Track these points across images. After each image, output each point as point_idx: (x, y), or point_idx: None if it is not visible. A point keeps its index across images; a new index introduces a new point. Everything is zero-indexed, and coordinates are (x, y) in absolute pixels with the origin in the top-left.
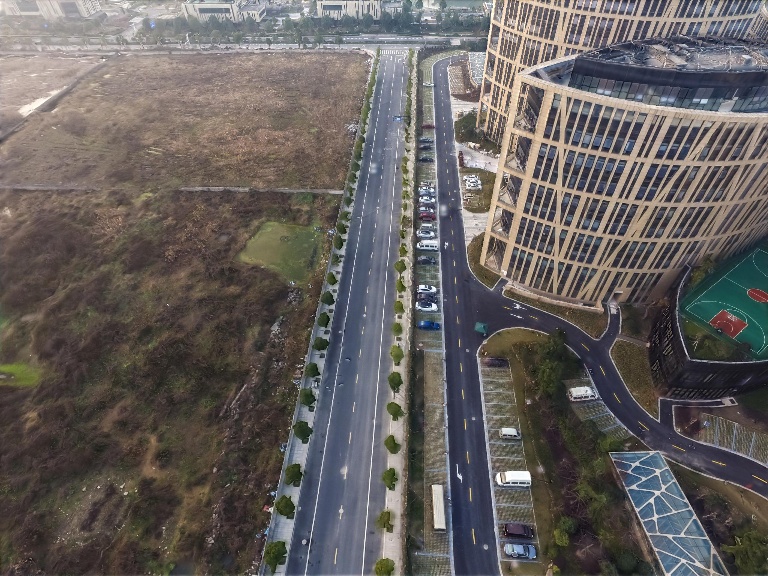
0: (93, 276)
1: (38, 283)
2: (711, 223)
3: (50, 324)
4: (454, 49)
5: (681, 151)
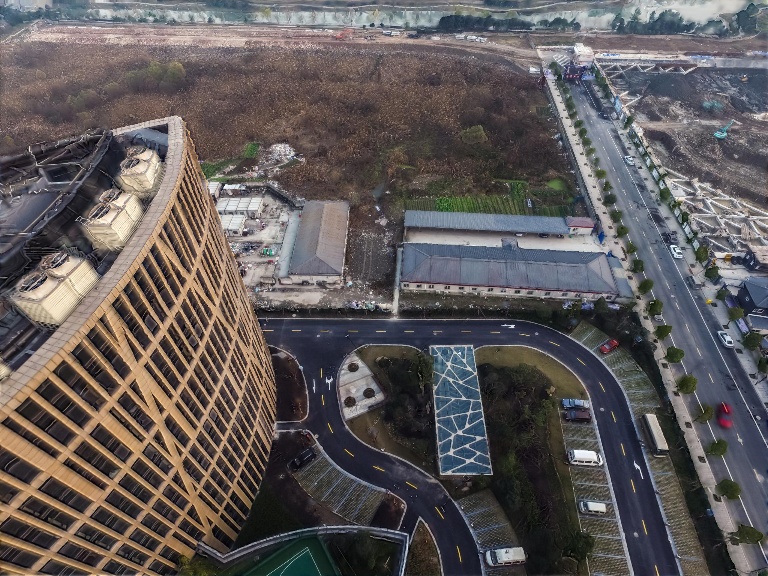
0: None
1: None
2: None
3: None
4: None
5: None
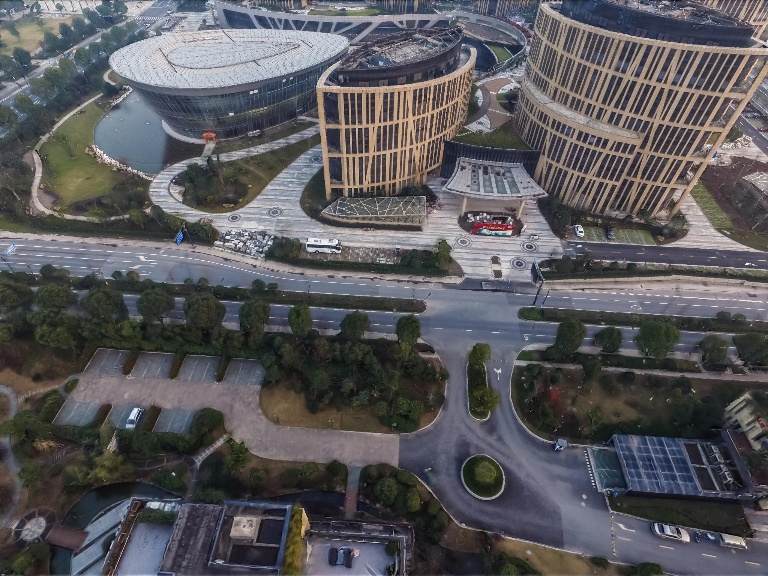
0: None
1: None
2: None
3: None
4: None
5: None
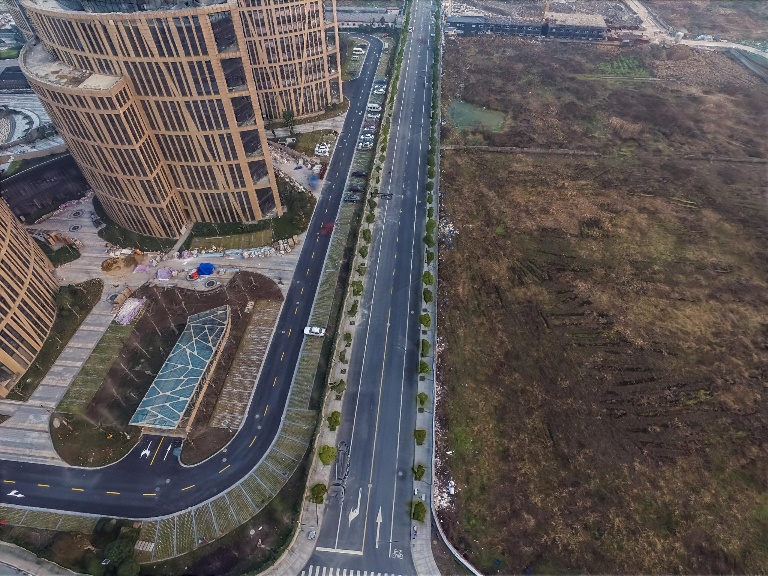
0: (593, 102)
1: (623, 97)
2: None
3: (587, 83)
4: (165, 571)
5: None
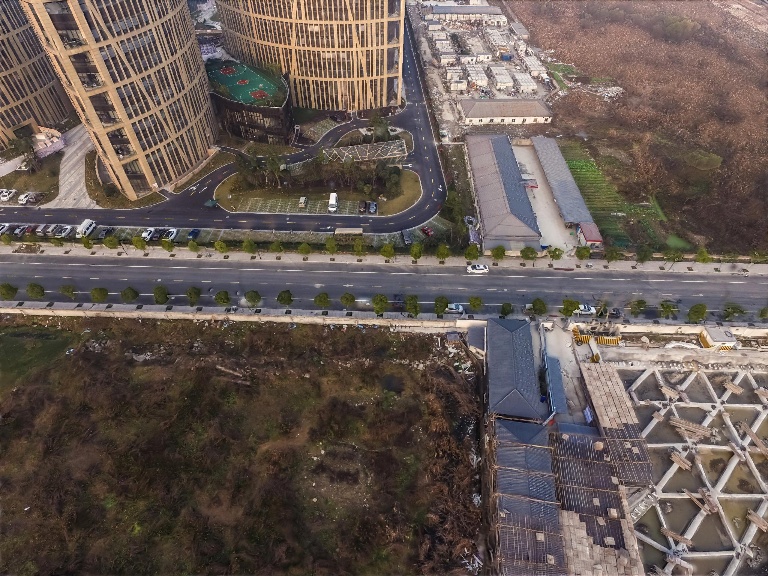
0: None
1: None
2: (198, 56)
3: None
4: None
5: (164, 7)
